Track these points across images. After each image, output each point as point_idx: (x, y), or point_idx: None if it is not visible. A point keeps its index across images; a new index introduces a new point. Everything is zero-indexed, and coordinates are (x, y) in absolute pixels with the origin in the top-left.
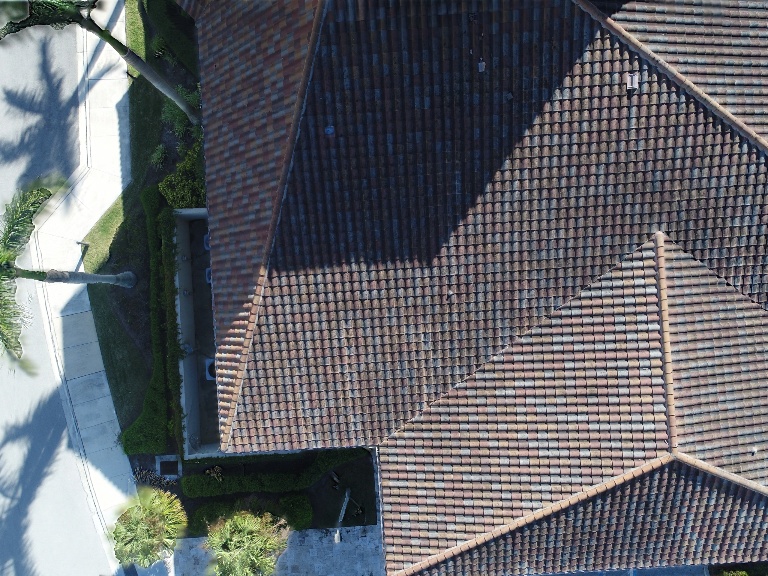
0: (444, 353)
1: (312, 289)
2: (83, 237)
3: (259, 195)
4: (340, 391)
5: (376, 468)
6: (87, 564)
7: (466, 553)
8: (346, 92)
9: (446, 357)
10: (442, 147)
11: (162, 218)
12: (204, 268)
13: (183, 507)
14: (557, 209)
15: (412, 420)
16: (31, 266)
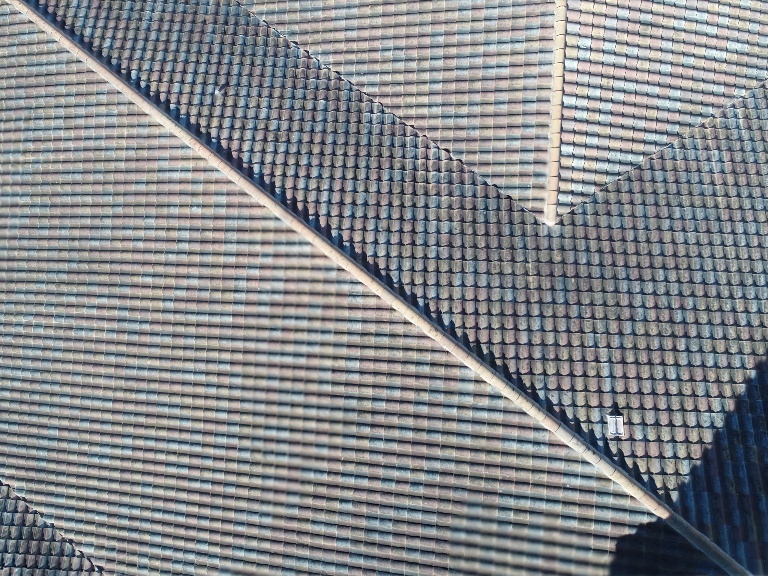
0: None
1: None
2: None
3: None
4: None
5: None
6: None
7: None
8: None
9: None
10: None
11: None
12: None
13: None
14: (691, 270)
15: None
16: None
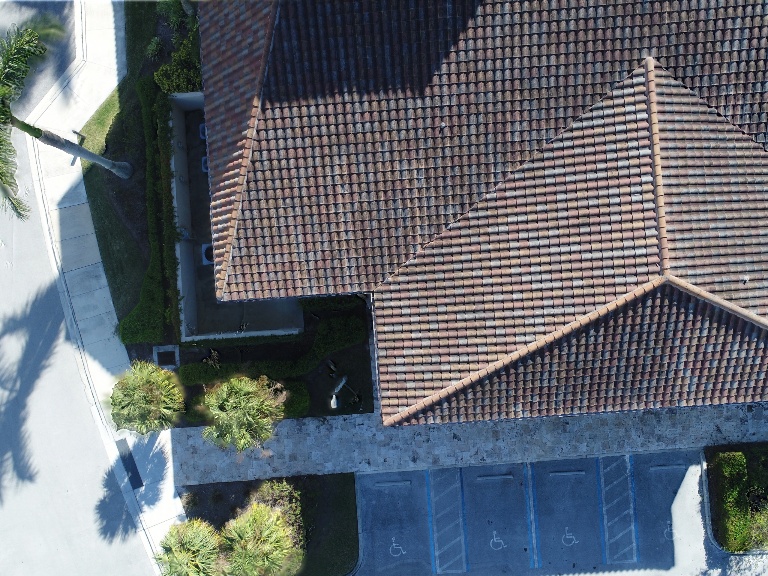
0: (437, 191)
1: (305, 122)
2: (79, 130)
3: (252, 27)
4: (334, 233)
5: (373, 356)
6: (85, 455)
7: (461, 393)
8: None
9: (439, 195)
10: None
11: (157, 102)
12: (200, 159)
13: (181, 395)
14: (548, 34)
15: (406, 264)
16: (28, 159)
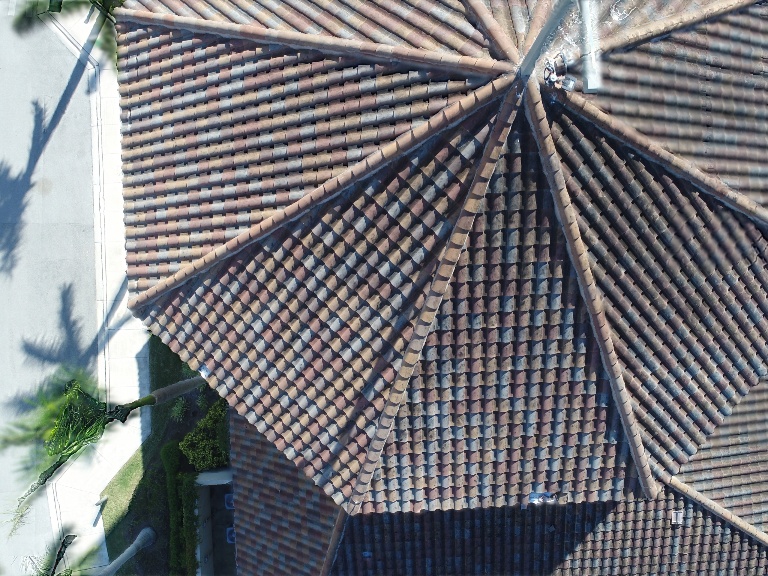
0: None
1: None
2: (102, 490)
3: None
4: None
5: None
6: None
7: None
8: (385, 525)
9: None
10: (481, 568)
11: (183, 490)
12: (224, 523)
13: None
14: None
15: None
16: (49, 517)
